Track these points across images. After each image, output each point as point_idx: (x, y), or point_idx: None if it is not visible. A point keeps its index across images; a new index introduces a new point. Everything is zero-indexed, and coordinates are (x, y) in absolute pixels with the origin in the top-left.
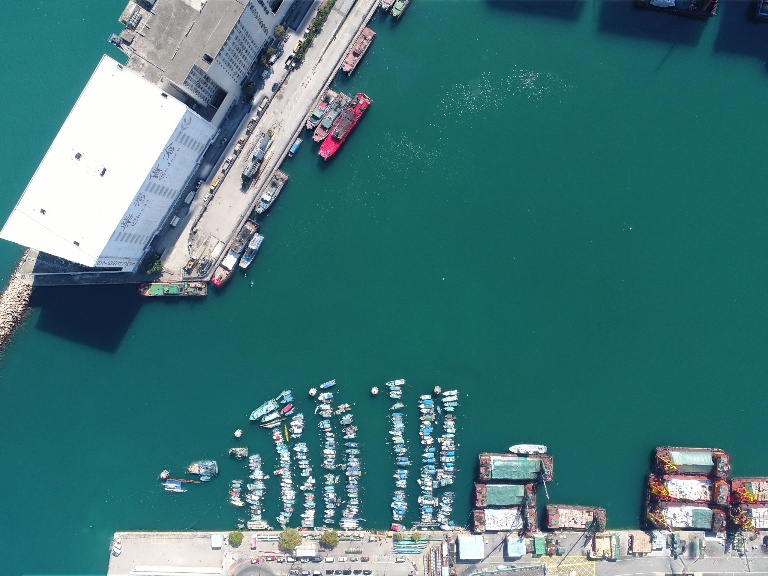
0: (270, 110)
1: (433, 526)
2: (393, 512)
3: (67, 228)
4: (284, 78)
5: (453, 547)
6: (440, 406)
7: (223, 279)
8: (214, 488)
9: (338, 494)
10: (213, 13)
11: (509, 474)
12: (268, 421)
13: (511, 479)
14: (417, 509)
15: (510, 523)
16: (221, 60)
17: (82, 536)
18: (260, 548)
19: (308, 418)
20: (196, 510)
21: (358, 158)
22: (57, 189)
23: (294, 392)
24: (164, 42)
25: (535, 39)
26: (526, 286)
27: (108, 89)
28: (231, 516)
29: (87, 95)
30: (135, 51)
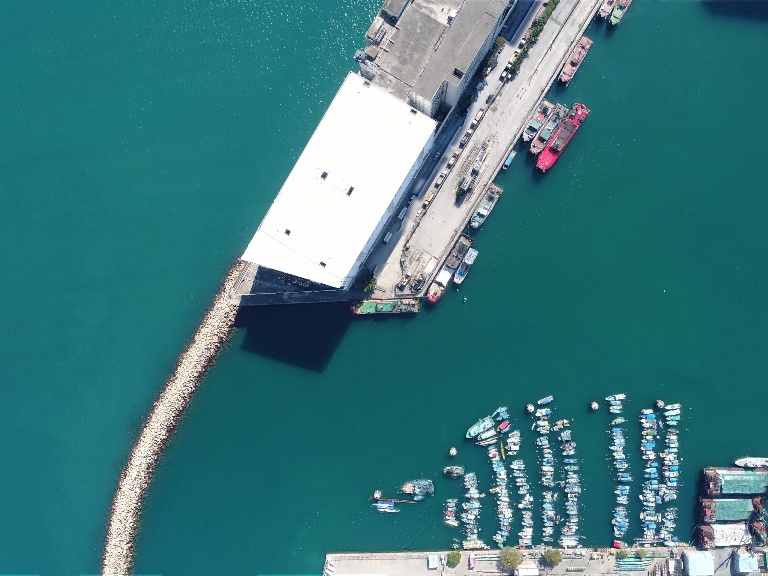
0: (484, 123)
1: (656, 542)
2: (614, 529)
3: (312, 249)
4: (499, 90)
5: (680, 564)
6: (662, 420)
7: (438, 295)
8: (428, 508)
9: (557, 511)
10: (463, 27)
11: (740, 488)
12: (484, 439)
13: (741, 493)
14: (639, 525)
15: (739, 538)
16: (466, 74)
17: (291, 559)
18: (478, 568)
19: (525, 435)
20: (409, 530)
21: (574, 169)
22: (303, 209)
23: (510, 409)
24: (409, 57)
25: (757, 45)
26: (750, 296)
27: (355, 106)
28: (446, 536)
29: (331, 113)
30: (379, 67)
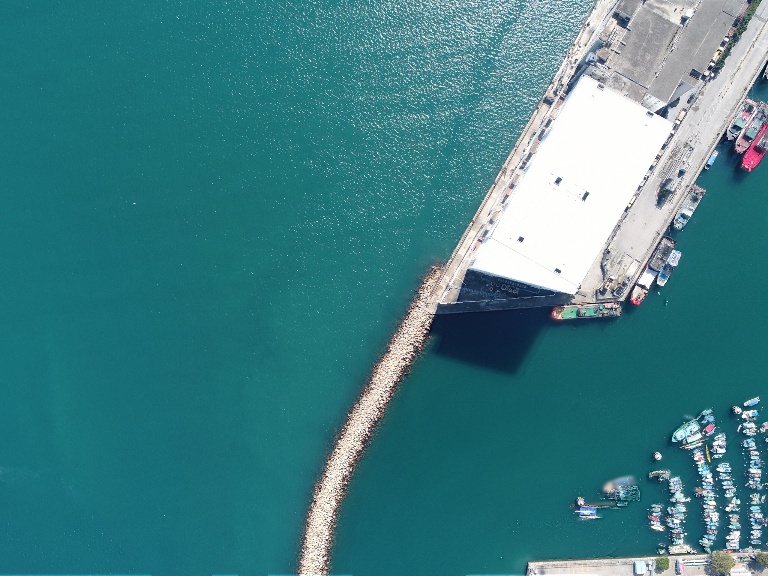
0: (686, 123)
1: None
2: None
3: (545, 255)
4: (701, 89)
5: None
6: None
7: (641, 299)
8: (631, 513)
9: (764, 514)
10: (700, 26)
11: None
12: (690, 442)
13: None
14: None
15: None
16: None
17: (491, 568)
18: (685, 573)
19: (730, 437)
20: (613, 537)
21: None
22: (536, 216)
23: (715, 411)
24: (641, 59)
25: None
26: None
27: (590, 110)
28: (650, 541)
29: (563, 117)
30: (610, 69)
